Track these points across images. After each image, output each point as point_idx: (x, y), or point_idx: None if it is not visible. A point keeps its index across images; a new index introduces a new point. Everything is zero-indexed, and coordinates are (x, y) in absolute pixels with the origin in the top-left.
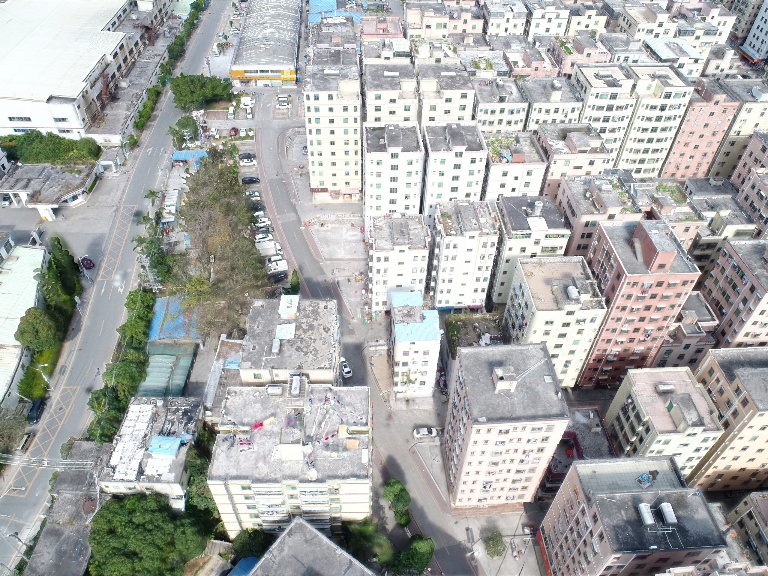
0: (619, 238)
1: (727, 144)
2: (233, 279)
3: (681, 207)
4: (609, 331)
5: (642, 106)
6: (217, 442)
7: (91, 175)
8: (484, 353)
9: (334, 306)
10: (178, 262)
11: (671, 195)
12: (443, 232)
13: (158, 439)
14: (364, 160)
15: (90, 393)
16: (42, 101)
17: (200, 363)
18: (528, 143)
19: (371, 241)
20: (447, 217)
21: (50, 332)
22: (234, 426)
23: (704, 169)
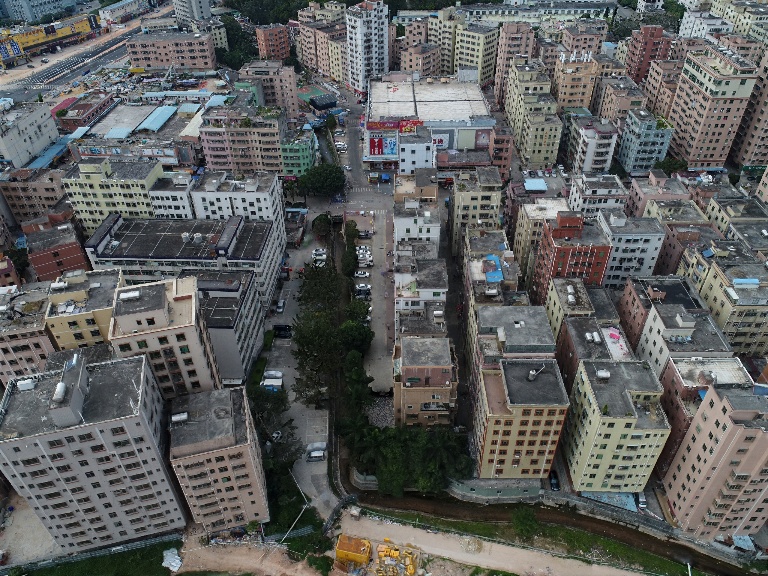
0: None
1: None
2: None
3: None
4: None
5: None
6: None
7: None
8: None
9: (605, 25)
10: None
11: None
12: None
13: None
14: None
15: None
16: None
17: None
18: None
19: None
20: None
21: None
22: None
23: None
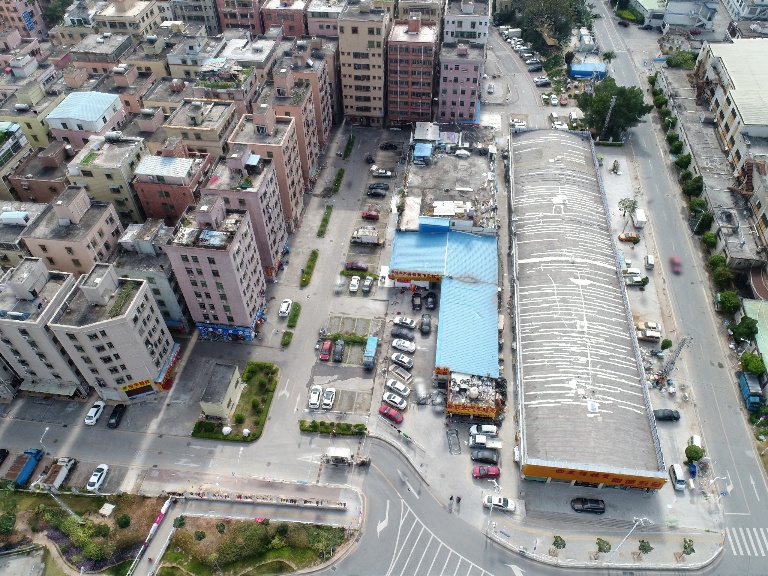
0: None
1: None
2: None
3: None
4: None
5: None
6: None
7: None
8: None
9: None
10: None
11: None
12: None
13: None
14: None
15: None
16: None
17: None
18: None
19: None
20: None
21: None
22: None
23: None
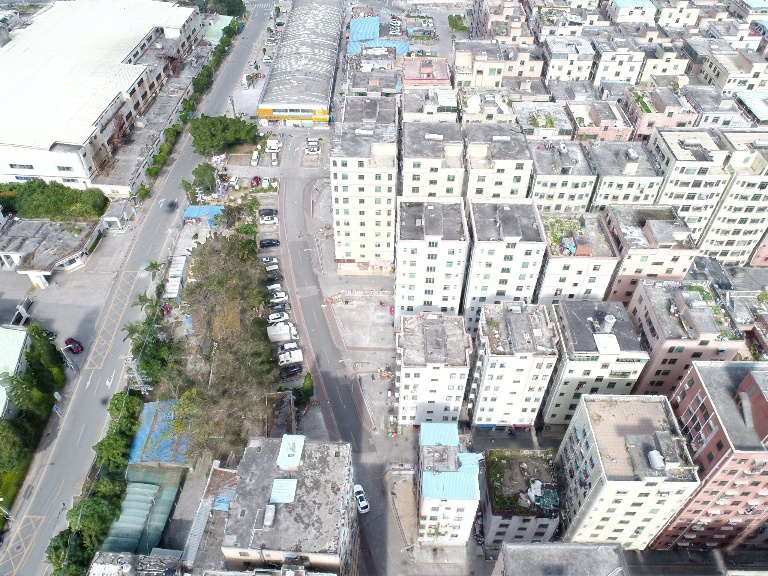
0: (719, 386)
1: None
2: None
3: None
4: (699, 503)
5: (737, 183)
6: None
7: (92, 235)
8: (537, 552)
9: (347, 453)
10: (175, 355)
11: None
12: (488, 349)
13: None
14: None
15: (55, 527)
16: (44, 149)
17: (188, 492)
18: (595, 227)
19: (399, 351)
20: (494, 325)
21: (14, 450)
22: None
23: None
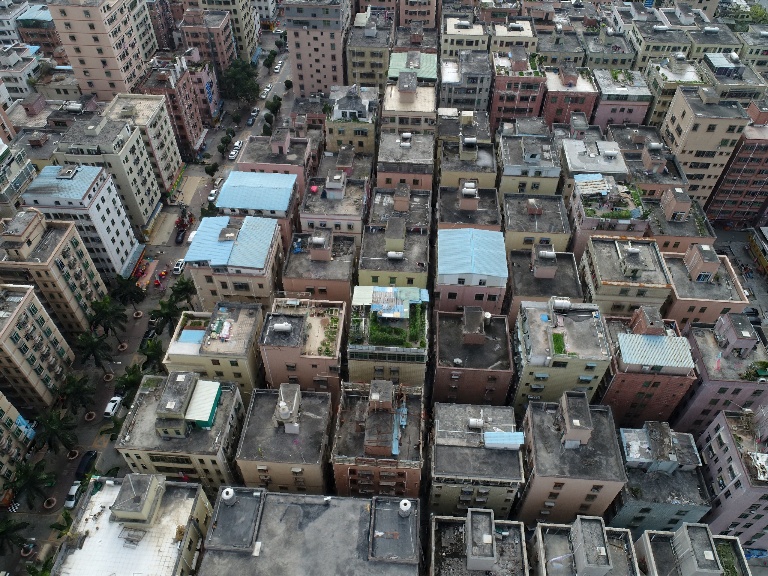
0: None
1: None
2: None
3: (486, 1)
4: None
5: None
6: None
7: None
8: None
9: None
10: None
11: None
12: None
13: None
14: None
15: None
16: None
17: None
18: None
19: None
20: None
21: None
22: None
23: None
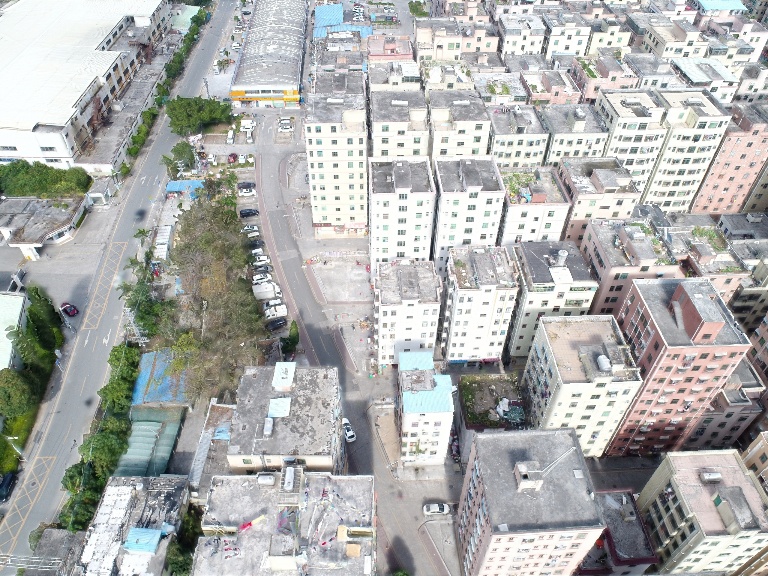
0: (656, 299)
1: (765, 176)
2: (225, 334)
3: (721, 255)
4: (643, 402)
5: (673, 136)
6: (199, 547)
7: (79, 210)
8: (504, 439)
9: (335, 375)
10: (167, 311)
11: (709, 241)
12: (456, 285)
13: (135, 532)
14: (370, 199)
15: (67, 465)
16: (28, 130)
17: (188, 429)
18: (549, 179)
19: (377, 293)
20: (461, 266)
21: (23, 397)
22: (219, 526)
23: (739, 201)
